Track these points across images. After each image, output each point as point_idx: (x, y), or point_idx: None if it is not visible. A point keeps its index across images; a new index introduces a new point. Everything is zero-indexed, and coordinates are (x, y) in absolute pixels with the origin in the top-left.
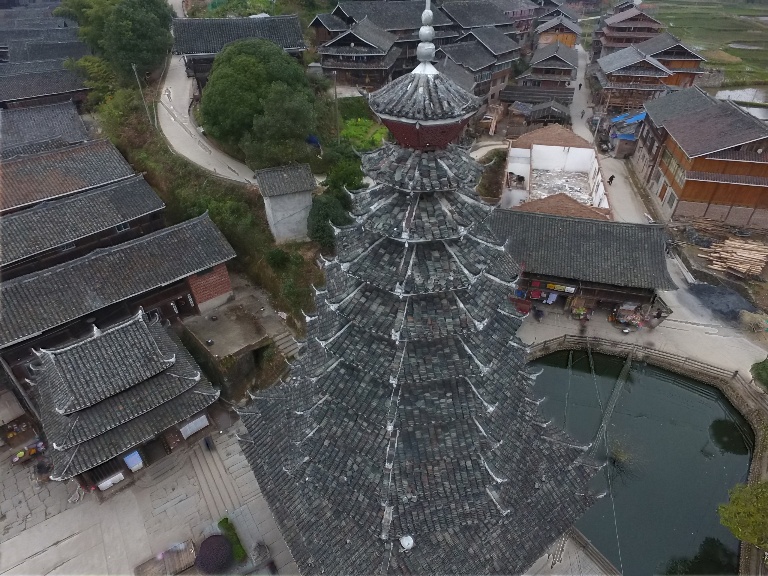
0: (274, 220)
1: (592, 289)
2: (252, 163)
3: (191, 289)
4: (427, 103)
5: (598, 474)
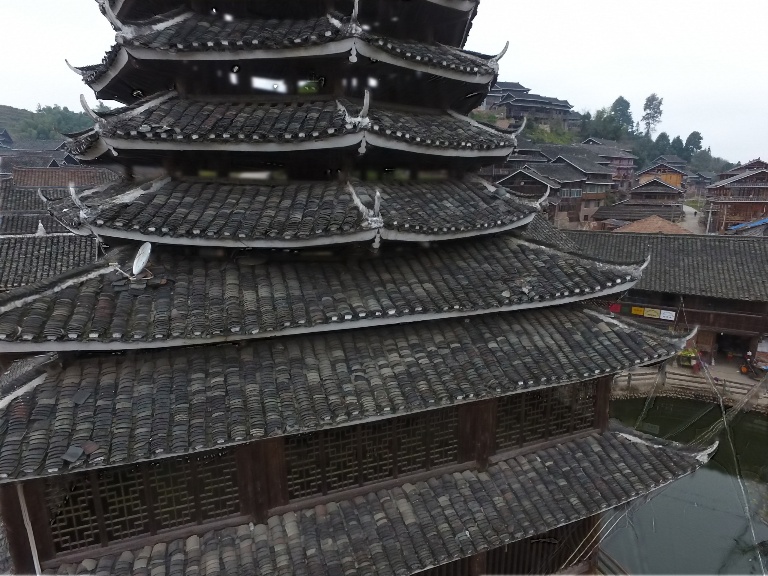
0: None
1: (703, 312)
2: None
3: None
4: None
5: (739, 569)
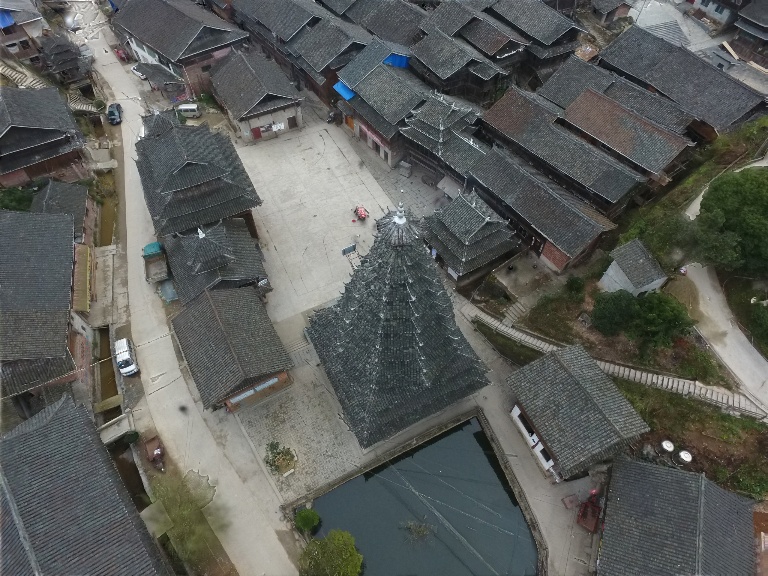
0: (607, 271)
1: None
2: (647, 234)
3: (545, 244)
4: (382, 223)
5: None
